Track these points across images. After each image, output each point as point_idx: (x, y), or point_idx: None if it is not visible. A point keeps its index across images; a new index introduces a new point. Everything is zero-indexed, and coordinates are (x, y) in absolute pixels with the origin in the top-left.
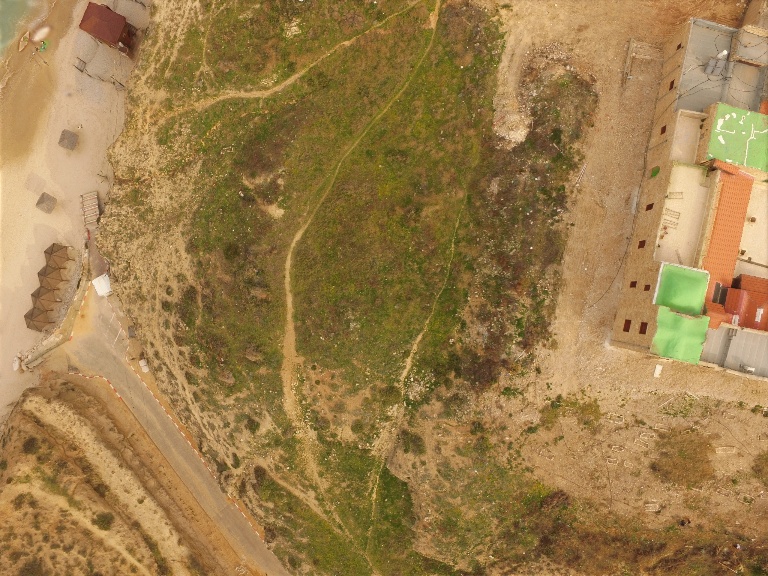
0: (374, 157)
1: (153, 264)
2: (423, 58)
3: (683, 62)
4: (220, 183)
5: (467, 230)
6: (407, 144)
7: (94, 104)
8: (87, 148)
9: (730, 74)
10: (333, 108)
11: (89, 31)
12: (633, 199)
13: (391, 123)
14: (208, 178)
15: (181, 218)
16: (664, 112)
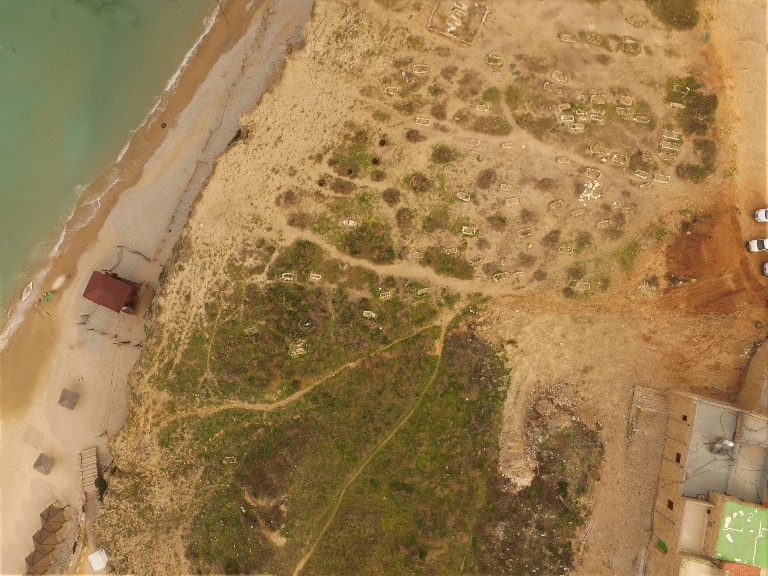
0: (378, 488)
1: (151, 564)
2: (428, 386)
3: (689, 444)
4: (222, 493)
5: (472, 574)
6: (412, 478)
7: (96, 356)
8: (87, 401)
9: (736, 456)
10: (337, 430)
11: (93, 300)
12: (640, 561)
13: (396, 452)
14: (210, 485)
15: (181, 521)
16: (671, 484)
